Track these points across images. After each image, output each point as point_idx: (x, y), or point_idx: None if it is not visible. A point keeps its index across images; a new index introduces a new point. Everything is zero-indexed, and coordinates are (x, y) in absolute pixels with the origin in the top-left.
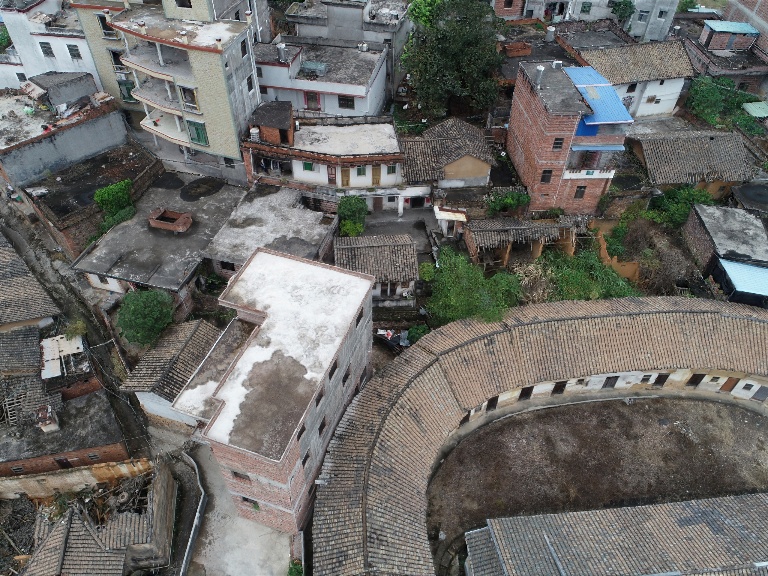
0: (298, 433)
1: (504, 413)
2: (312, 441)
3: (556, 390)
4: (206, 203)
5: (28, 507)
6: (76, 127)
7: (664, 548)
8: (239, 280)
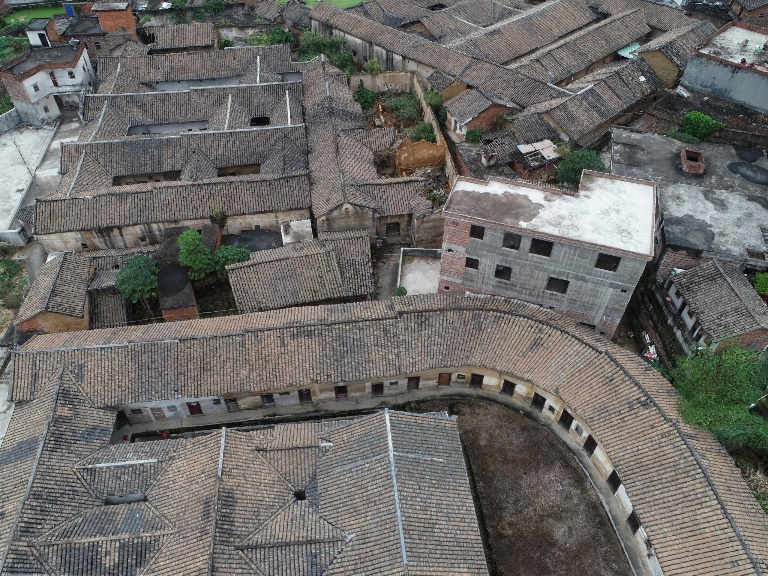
0: (479, 235)
1: (588, 467)
2: (485, 261)
3: (634, 524)
4: (733, 178)
5: (443, 183)
6: (761, 76)
7: (435, 567)
8: (612, 180)
